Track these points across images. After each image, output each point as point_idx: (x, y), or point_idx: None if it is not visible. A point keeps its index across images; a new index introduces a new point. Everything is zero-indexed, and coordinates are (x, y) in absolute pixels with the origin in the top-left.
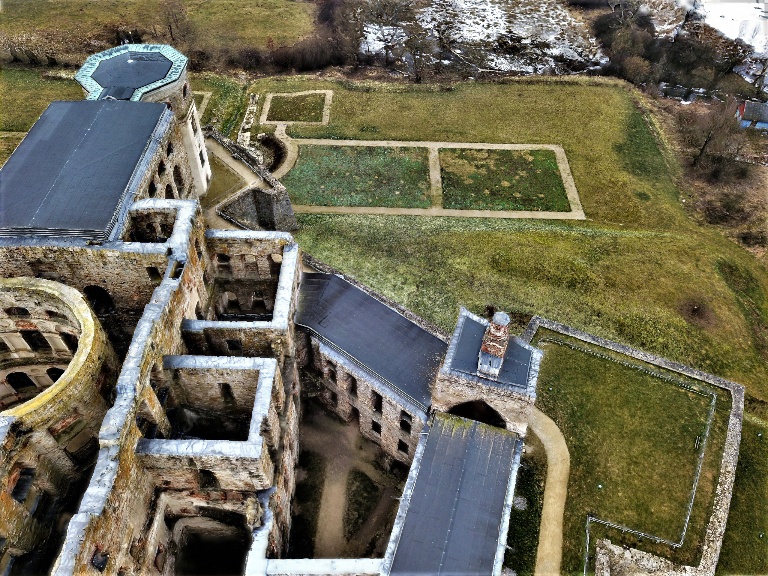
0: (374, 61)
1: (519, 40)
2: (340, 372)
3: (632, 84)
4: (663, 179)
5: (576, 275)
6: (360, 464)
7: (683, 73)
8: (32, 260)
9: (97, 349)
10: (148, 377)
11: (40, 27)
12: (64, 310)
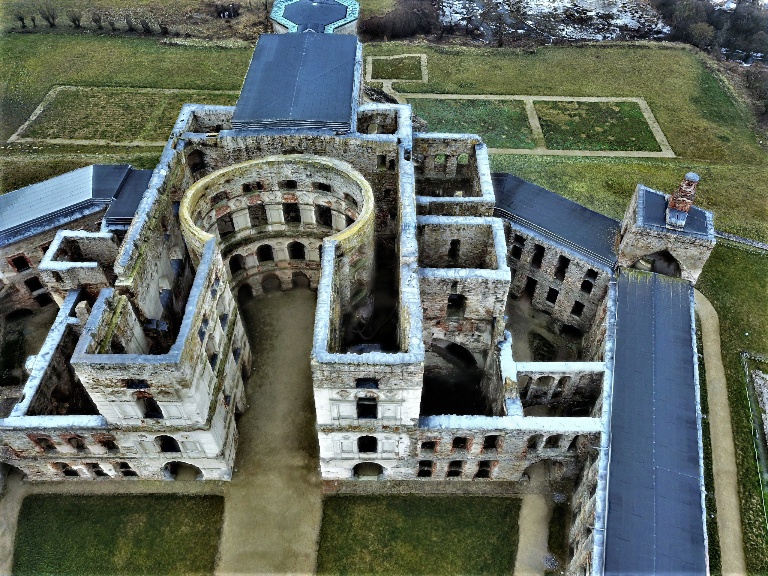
0: (455, 30)
1: (585, 12)
2: (528, 245)
3: (697, 48)
4: (739, 125)
5: None
6: (535, 328)
7: (741, 39)
8: (287, 148)
9: None
10: None
11: (143, 2)
12: (332, 179)
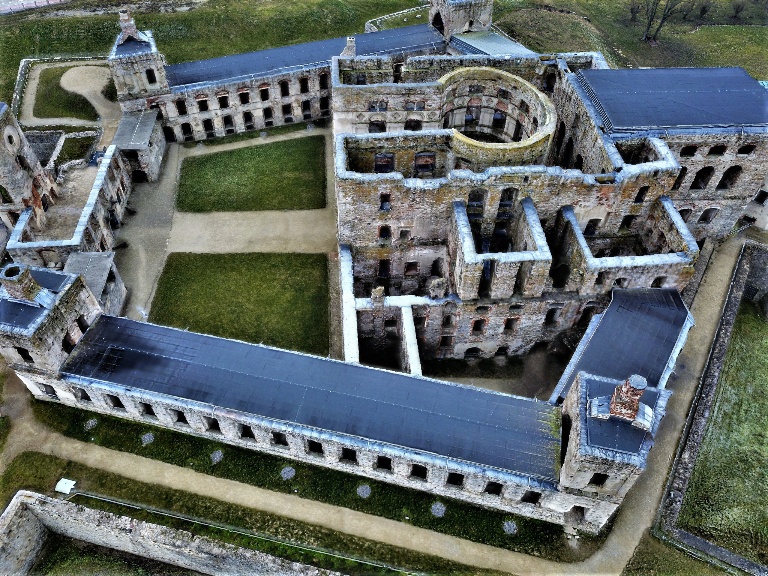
0: None
1: None
2: None
3: None
4: None
5: None
6: None
7: None
8: (578, 113)
9: (514, 155)
10: (505, 187)
11: None
12: None
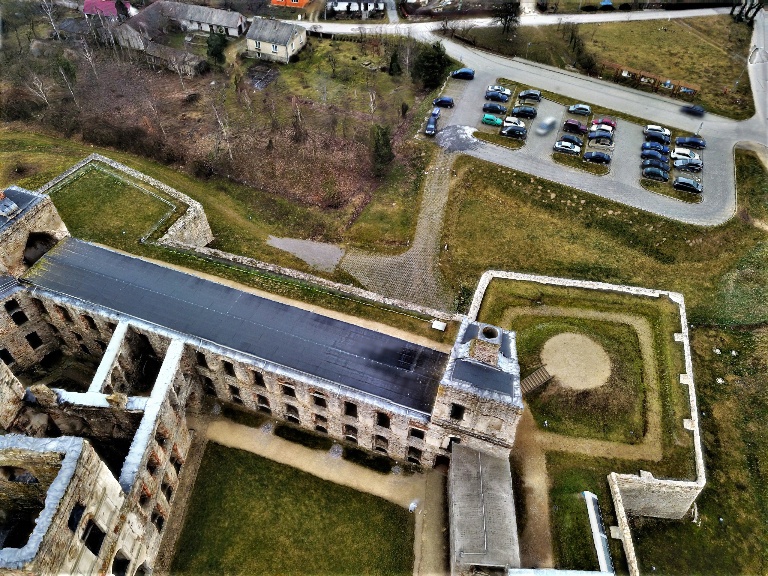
0: None
1: None
2: None
3: None
4: None
5: None
6: None
7: None
8: None
9: None
10: None
11: None
12: None
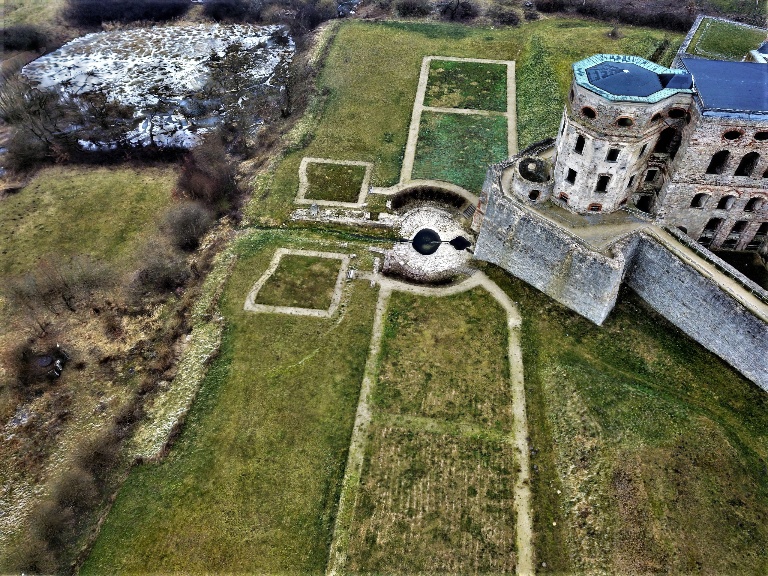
0: None
1: (218, 57)
2: None
3: (336, 19)
4: (468, 30)
5: None
6: None
7: None
8: None
9: None
10: None
11: None
12: None
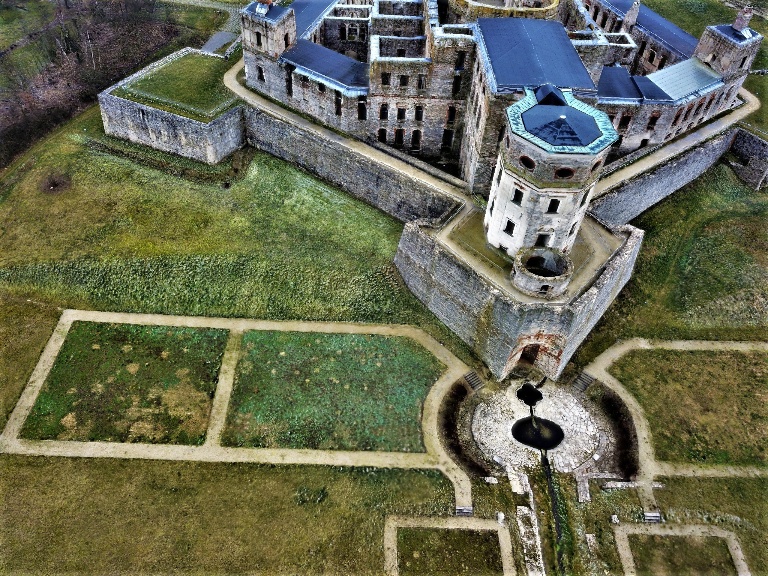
0: None
1: None
2: None
3: None
4: None
5: (138, 206)
6: None
7: None
8: None
9: None
10: None
11: None
12: None
